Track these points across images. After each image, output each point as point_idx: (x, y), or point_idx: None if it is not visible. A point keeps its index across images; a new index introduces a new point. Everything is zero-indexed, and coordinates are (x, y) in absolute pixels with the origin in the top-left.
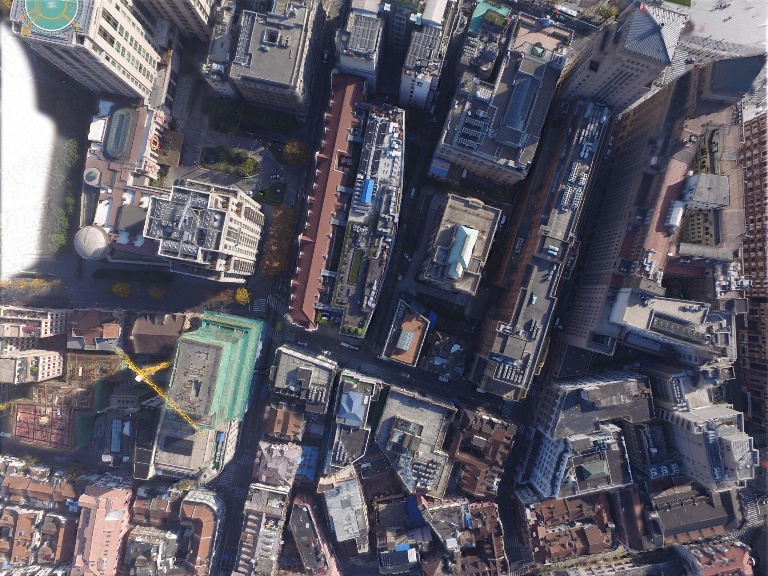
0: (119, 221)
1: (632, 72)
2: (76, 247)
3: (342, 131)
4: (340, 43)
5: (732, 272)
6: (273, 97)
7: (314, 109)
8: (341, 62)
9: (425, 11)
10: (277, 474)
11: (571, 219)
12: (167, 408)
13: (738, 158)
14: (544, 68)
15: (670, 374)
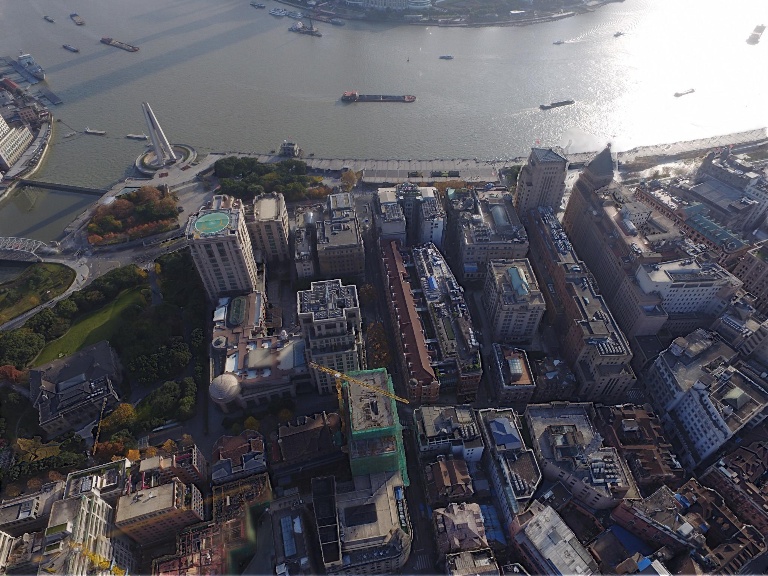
0: (246, 364)
1: (551, 176)
2: (212, 392)
3: (398, 263)
4: (380, 219)
5: (689, 244)
6: (344, 263)
7: (368, 274)
8: (383, 231)
9: (423, 195)
10: (468, 531)
11: (573, 256)
12: (354, 432)
13: (637, 198)
14: (502, 200)
15: (718, 318)
